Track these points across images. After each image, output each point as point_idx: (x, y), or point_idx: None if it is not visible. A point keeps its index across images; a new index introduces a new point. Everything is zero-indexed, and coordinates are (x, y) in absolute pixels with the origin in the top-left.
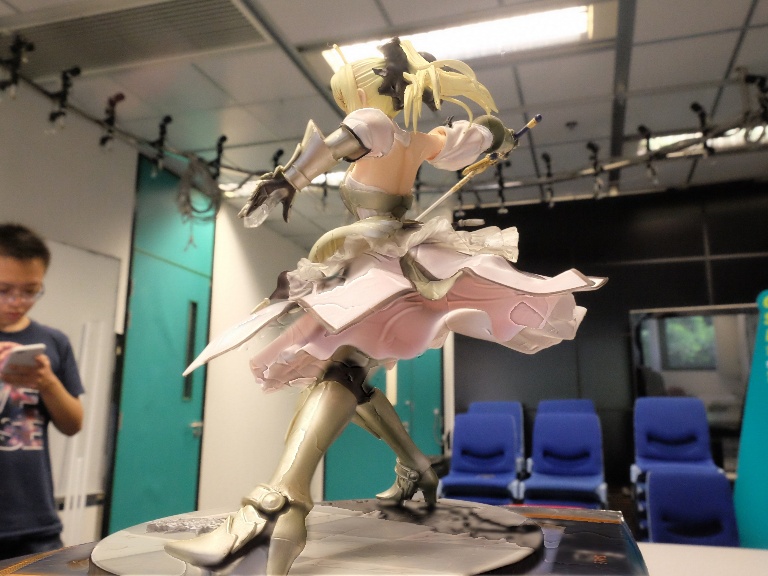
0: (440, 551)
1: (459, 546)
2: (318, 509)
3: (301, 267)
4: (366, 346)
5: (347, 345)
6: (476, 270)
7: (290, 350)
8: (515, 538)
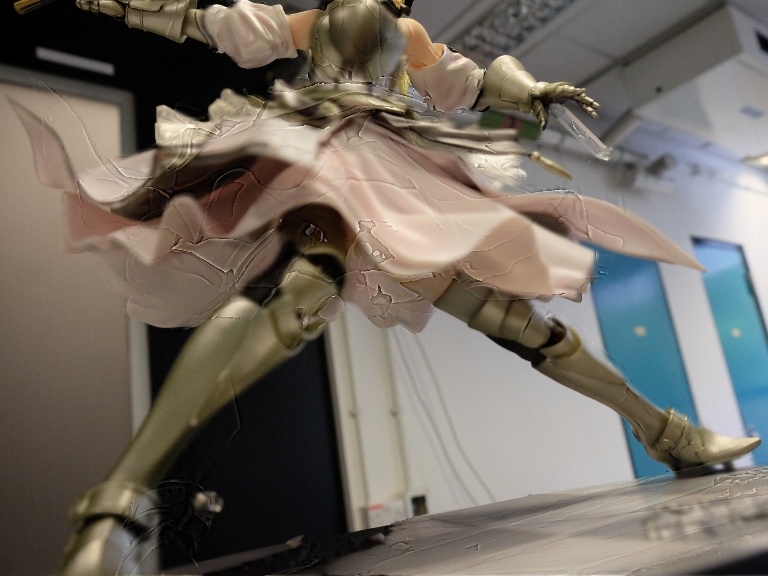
0: (501, 516)
1: None
2: None
3: None
4: None
5: (539, 295)
6: (429, 275)
7: None
8: (357, 557)
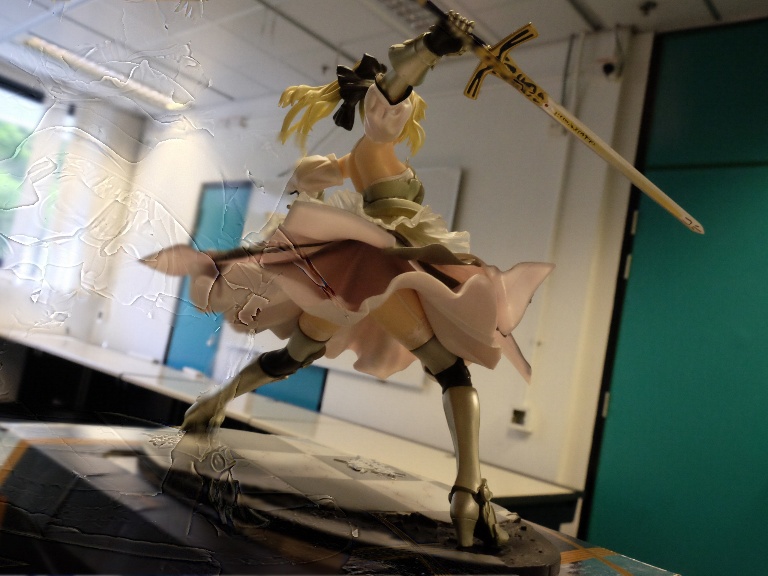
0: None
1: None
2: (256, 499)
3: (133, 203)
4: (16, 260)
5: (28, 263)
6: None
7: (84, 277)
8: None
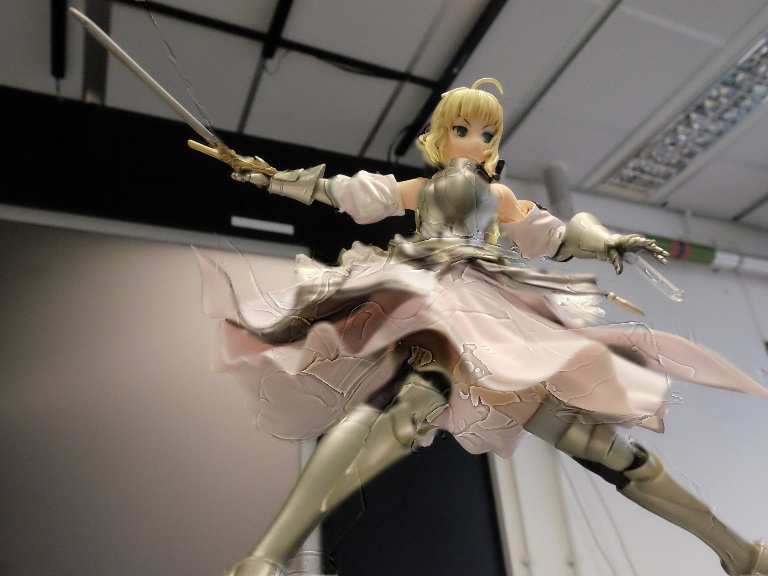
0: None
1: None
2: None
3: None
4: None
5: None
6: None
7: None
8: None
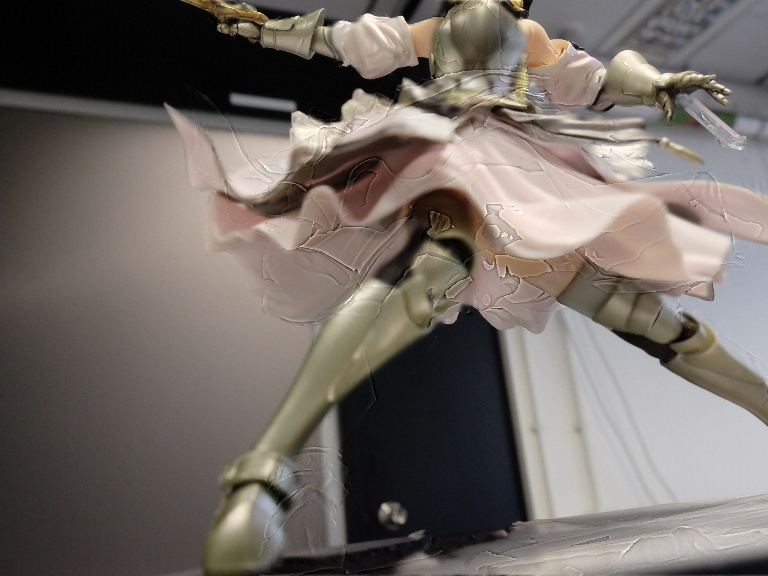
0: None
1: (592, 526)
2: None
3: None
4: None
5: None
6: None
7: None
8: None
